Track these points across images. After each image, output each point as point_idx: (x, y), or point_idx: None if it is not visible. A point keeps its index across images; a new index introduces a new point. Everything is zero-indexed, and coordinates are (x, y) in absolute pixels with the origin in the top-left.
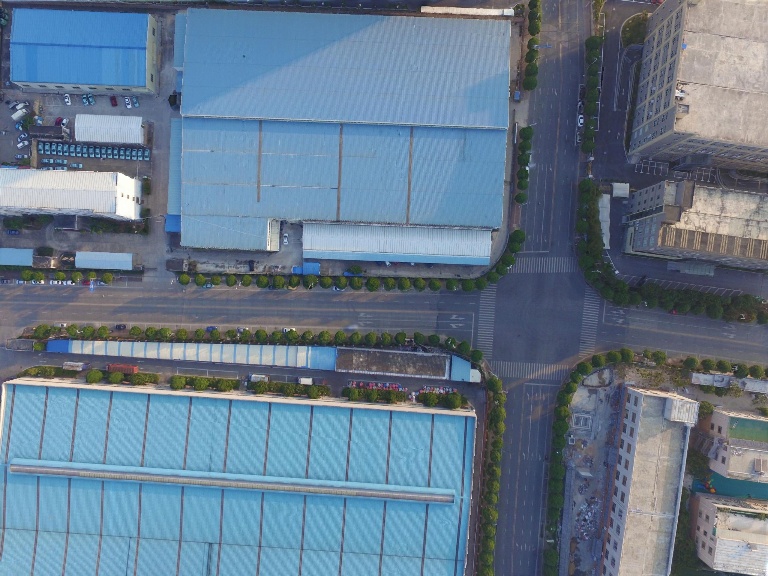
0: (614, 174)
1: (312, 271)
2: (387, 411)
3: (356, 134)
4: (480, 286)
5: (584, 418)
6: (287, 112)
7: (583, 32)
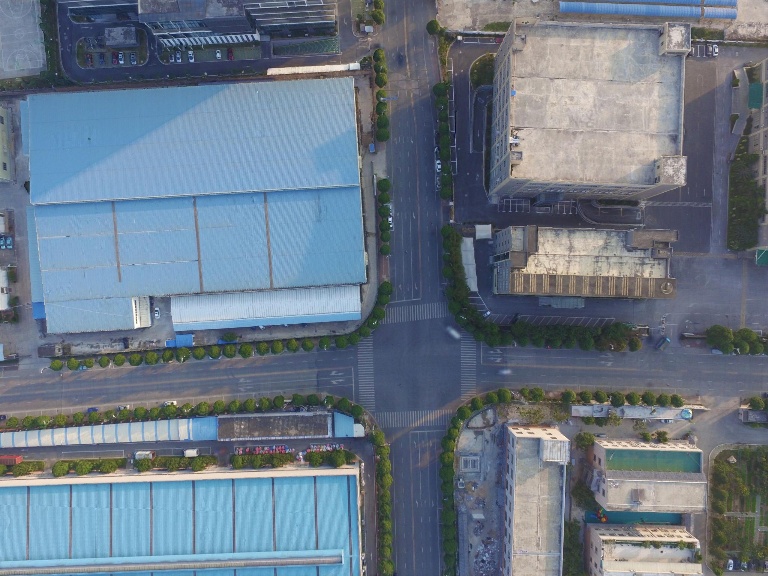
0: (477, 216)
1: (185, 343)
2: (268, 478)
3: (210, 205)
4: (352, 342)
5: (472, 460)
6: (137, 191)
7: (432, 78)
